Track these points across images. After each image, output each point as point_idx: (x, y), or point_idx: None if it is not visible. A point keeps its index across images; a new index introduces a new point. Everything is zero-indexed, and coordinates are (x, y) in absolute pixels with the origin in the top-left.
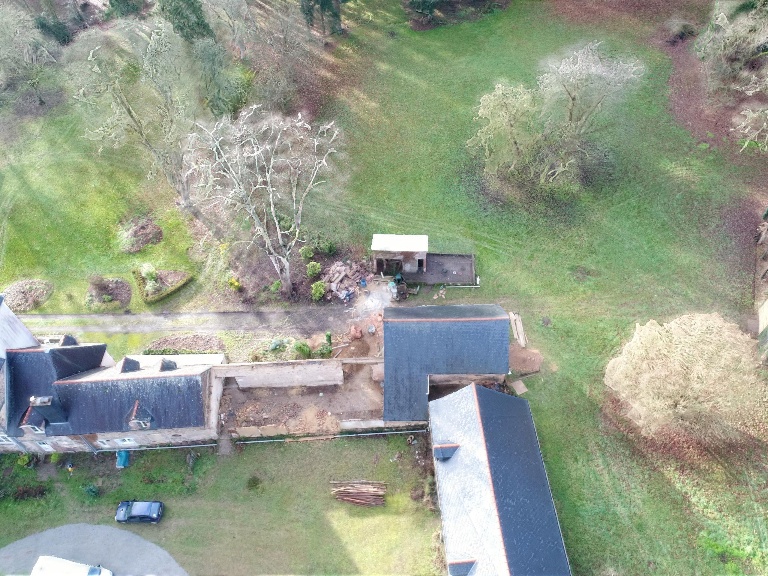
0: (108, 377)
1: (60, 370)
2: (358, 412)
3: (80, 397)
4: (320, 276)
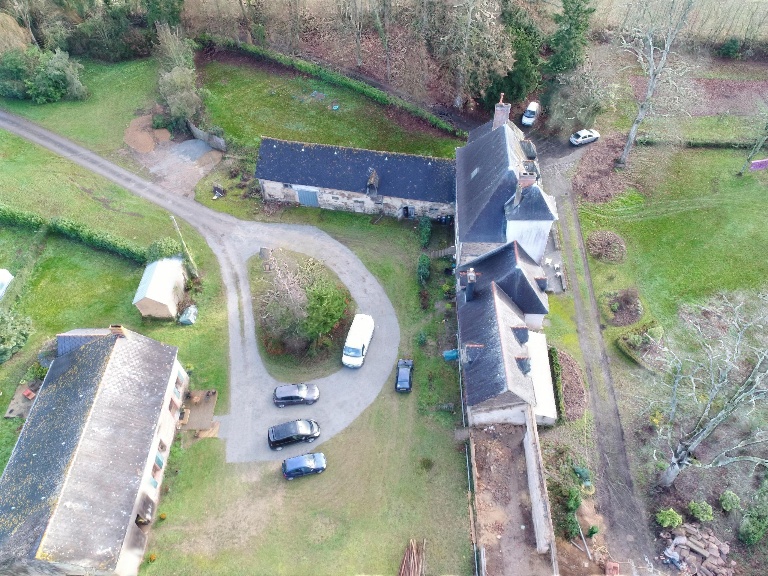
0: (502, 318)
1: (506, 282)
2: (503, 571)
3: (484, 303)
4: (696, 522)
